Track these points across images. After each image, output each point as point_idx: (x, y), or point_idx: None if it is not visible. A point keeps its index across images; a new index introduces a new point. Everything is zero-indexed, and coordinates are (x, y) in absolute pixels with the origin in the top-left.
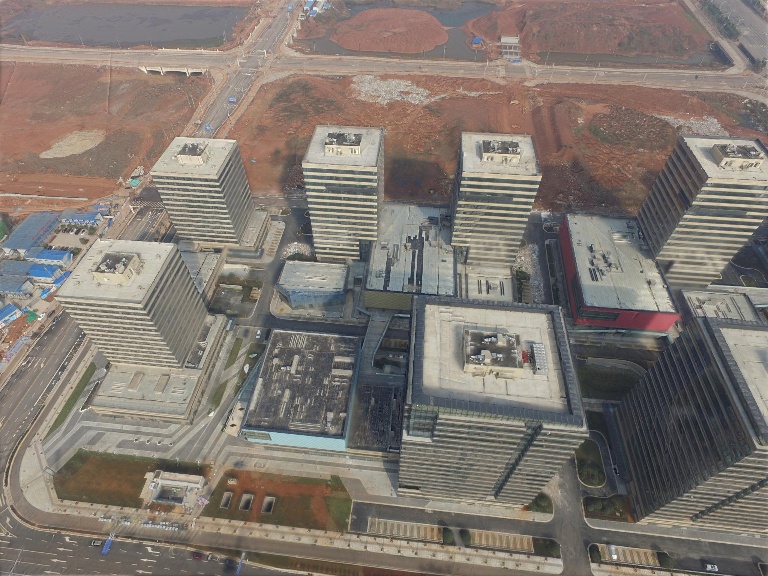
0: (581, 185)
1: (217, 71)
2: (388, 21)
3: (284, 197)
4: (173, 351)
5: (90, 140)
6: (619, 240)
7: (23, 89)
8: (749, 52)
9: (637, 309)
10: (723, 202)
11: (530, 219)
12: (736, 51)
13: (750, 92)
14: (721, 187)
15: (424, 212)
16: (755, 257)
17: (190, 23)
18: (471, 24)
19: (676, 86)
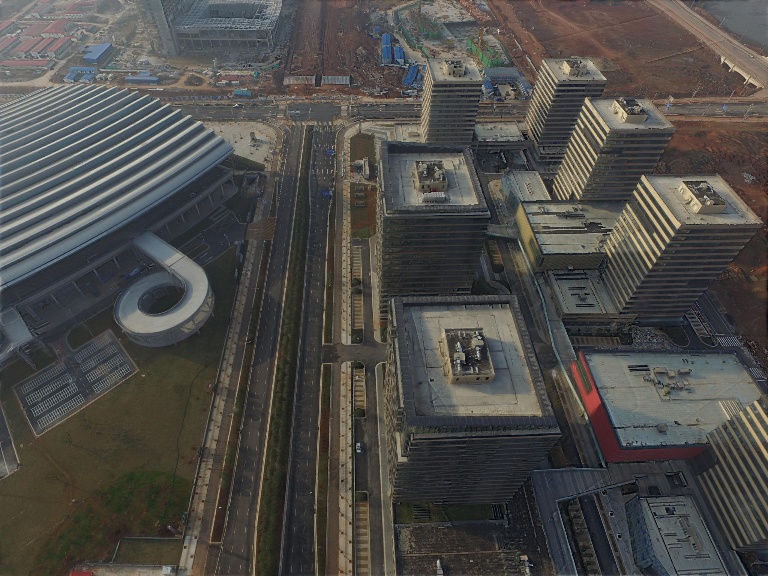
0: None
1: None
2: None
3: None
4: (429, 129)
5: (603, 65)
6: (724, 406)
7: (636, 26)
8: None
9: (606, 403)
10: None
11: None
12: None
13: None
14: None
15: None
16: None
17: None
18: None
19: None
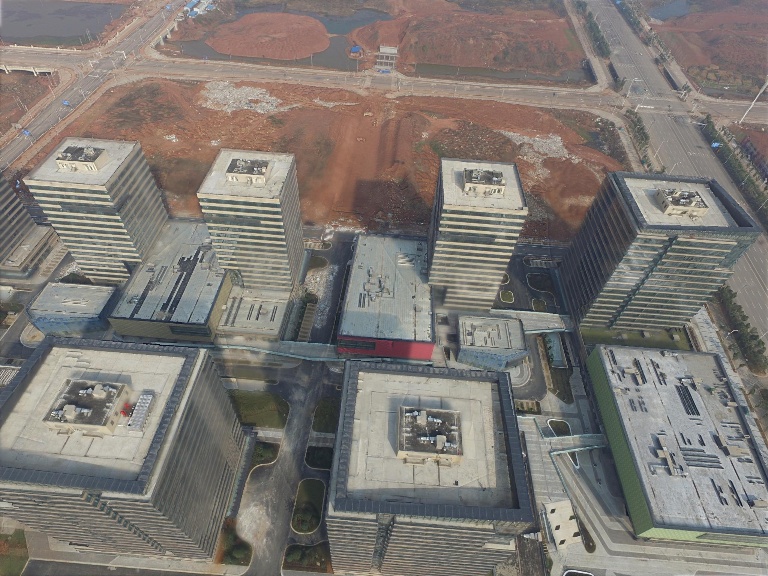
0: (404, 202)
1: (66, 71)
2: (271, 26)
3: None
4: None
5: None
6: (402, 263)
7: None
8: (616, 71)
9: (393, 338)
10: (468, 229)
11: (341, 237)
12: (604, 69)
13: (604, 111)
14: (460, 214)
15: None
16: (549, 280)
17: (61, 19)
18: (356, 32)
19: (535, 102)
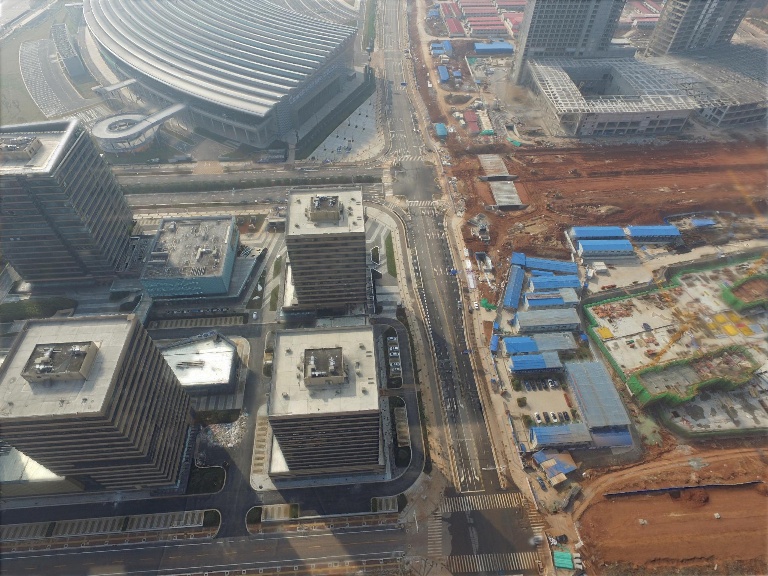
0: None
1: None
2: None
3: (265, 567)
4: None
5: None
6: None
7: None
8: None
9: None
10: None
11: None
12: None
13: None
14: None
15: (0, 470)
16: None
17: None
18: None
19: None
